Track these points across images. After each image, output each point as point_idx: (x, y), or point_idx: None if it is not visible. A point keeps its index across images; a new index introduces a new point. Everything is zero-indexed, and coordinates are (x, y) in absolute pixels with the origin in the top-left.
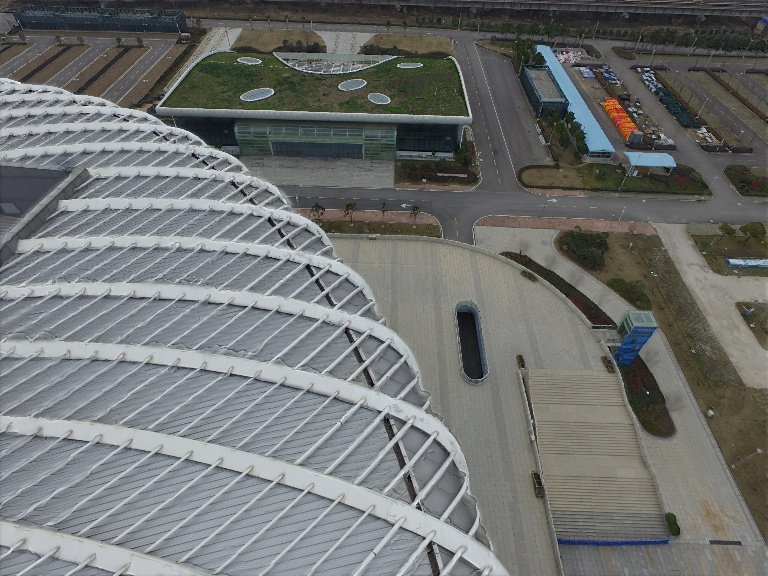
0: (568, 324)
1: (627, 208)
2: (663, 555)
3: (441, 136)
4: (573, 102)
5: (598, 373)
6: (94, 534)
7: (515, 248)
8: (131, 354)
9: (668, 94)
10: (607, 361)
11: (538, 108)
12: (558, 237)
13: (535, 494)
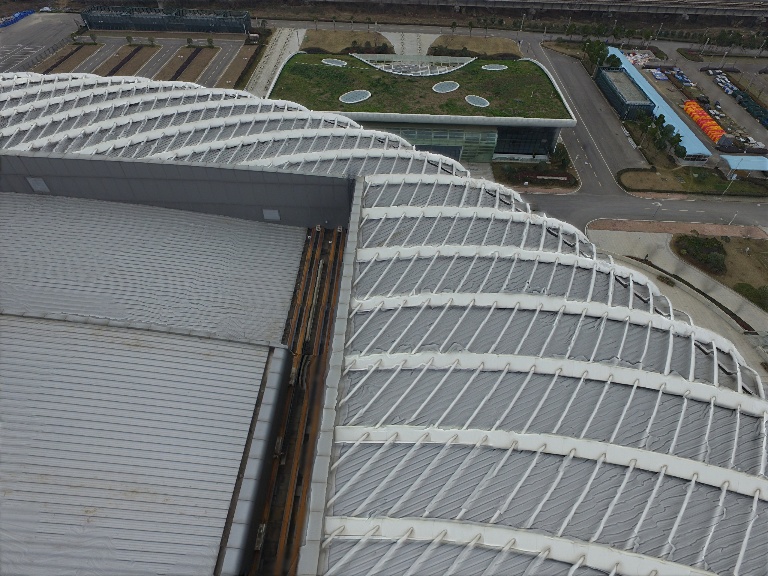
0: (718, 329)
1: (733, 212)
2: None
3: (537, 139)
4: (657, 105)
5: (762, 379)
6: (646, 550)
7: (633, 252)
8: (540, 366)
9: (746, 97)
10: None
11: (623, 110)
12: (673, 241)
13: None
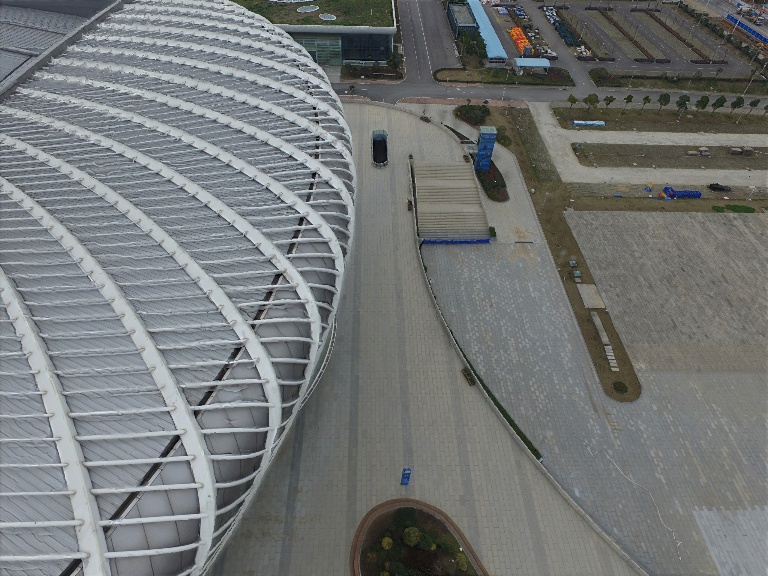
0: (446, 142)
1: (510, 93)
2: (485, 247)
3: (376, 47)
4: (483, 27)
5: (459, 163)
6: None
7: None
8: (185, 32)
9: (562, 24)
10: (465, 156)
11: (456, 31)
12: (456, 109)
13: (408, 209)
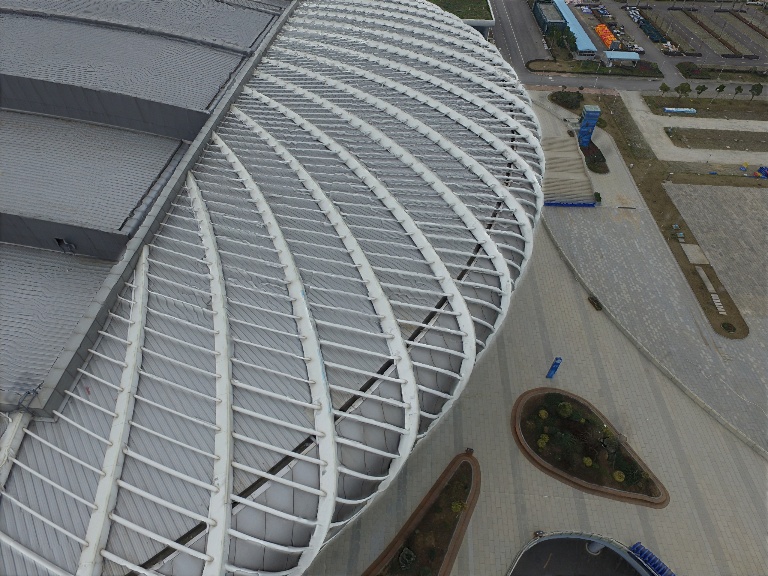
0: (549, 119)
1: (601, 83)
2: (591, 210)
3: None
4: (571, 24)
5: (564, 137)
6: None
7: None
8: (373, 3)
9: (647, 23)
10: (570, 131)
11: (544, 27)
12: (551, 94)
13: None
